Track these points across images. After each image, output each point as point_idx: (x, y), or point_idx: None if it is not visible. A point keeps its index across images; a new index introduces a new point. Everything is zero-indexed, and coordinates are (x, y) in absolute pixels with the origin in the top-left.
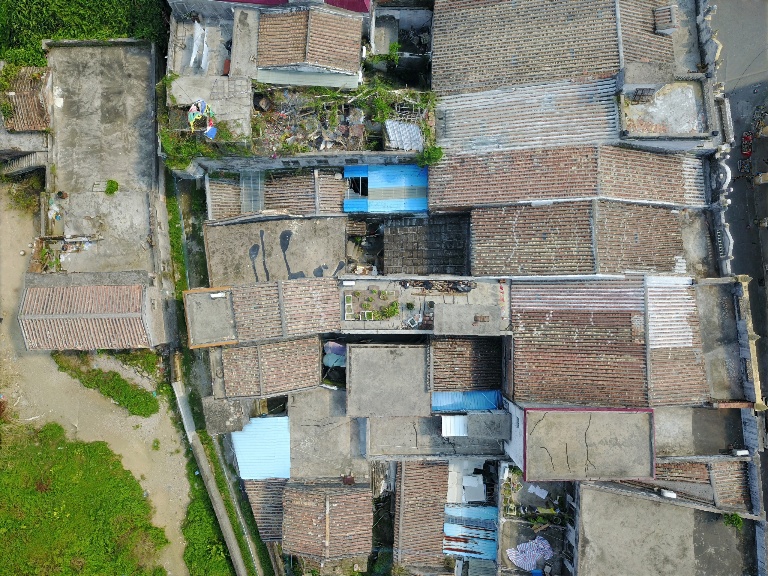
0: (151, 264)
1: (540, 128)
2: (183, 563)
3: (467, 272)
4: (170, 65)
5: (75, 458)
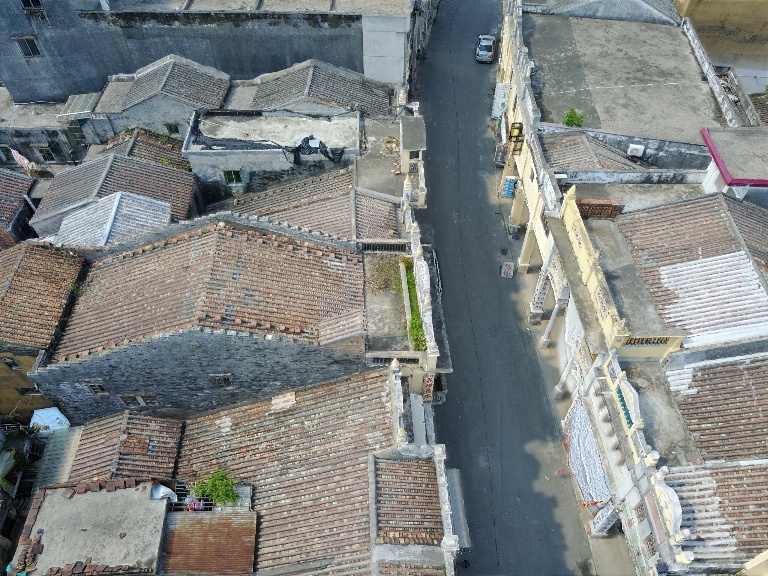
0: None
1: None
2: None
3: None
4: None
5: None
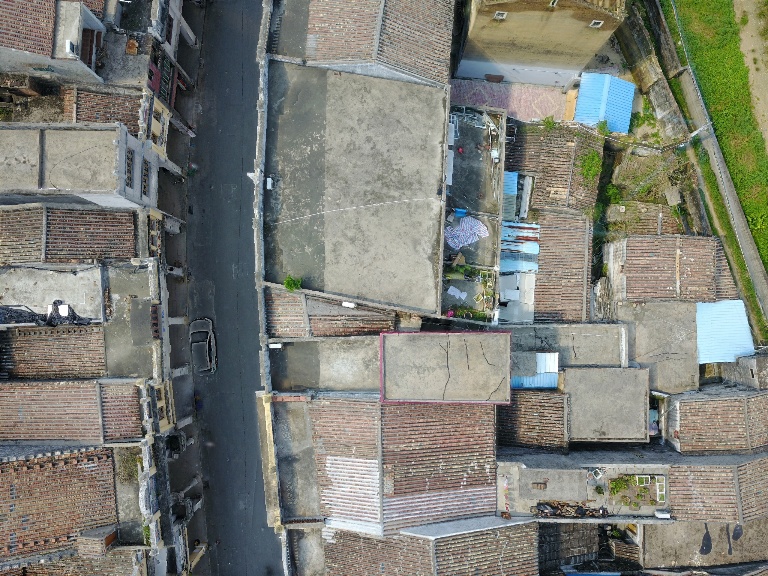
0: None
1: None
2: None
3: None
4: None
5: None
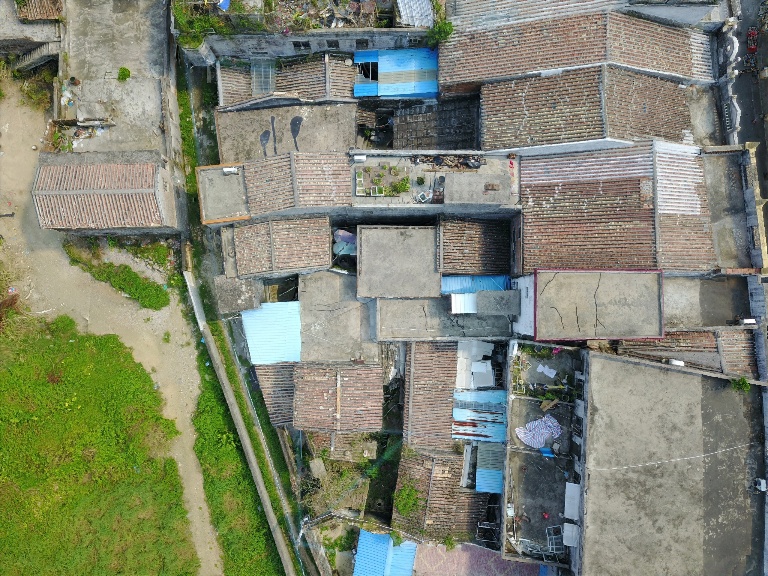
0: (163, 150)
1: None
2: (193, 455)
3: None
4: None
5: (86, 350)
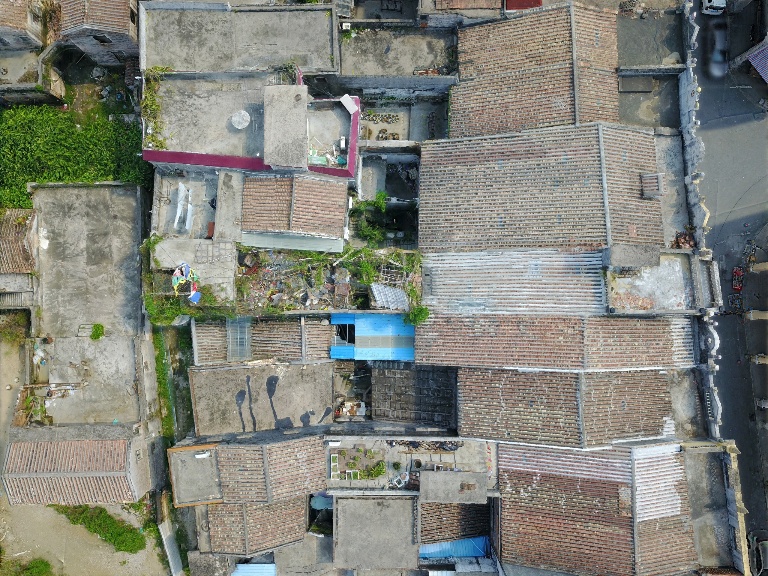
0: (137, 410)
1: (526, 294)
2: None
3: (455, 422)
4: (154, 222)
5: None
